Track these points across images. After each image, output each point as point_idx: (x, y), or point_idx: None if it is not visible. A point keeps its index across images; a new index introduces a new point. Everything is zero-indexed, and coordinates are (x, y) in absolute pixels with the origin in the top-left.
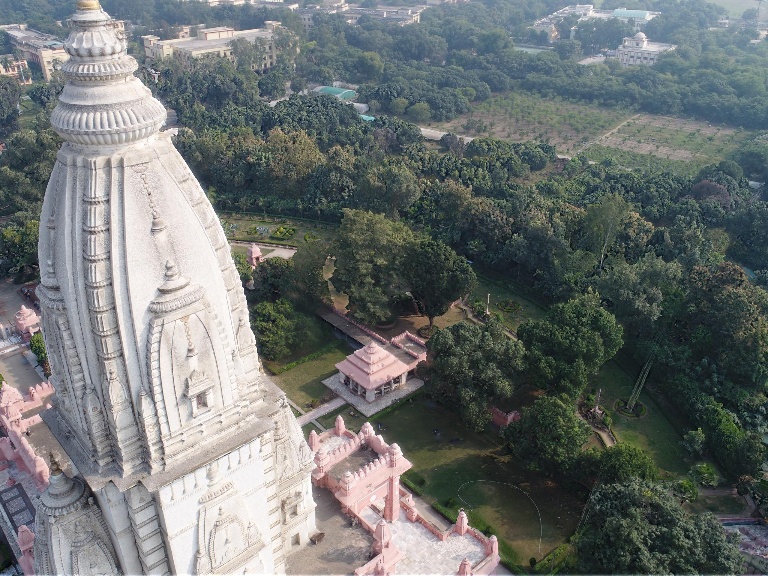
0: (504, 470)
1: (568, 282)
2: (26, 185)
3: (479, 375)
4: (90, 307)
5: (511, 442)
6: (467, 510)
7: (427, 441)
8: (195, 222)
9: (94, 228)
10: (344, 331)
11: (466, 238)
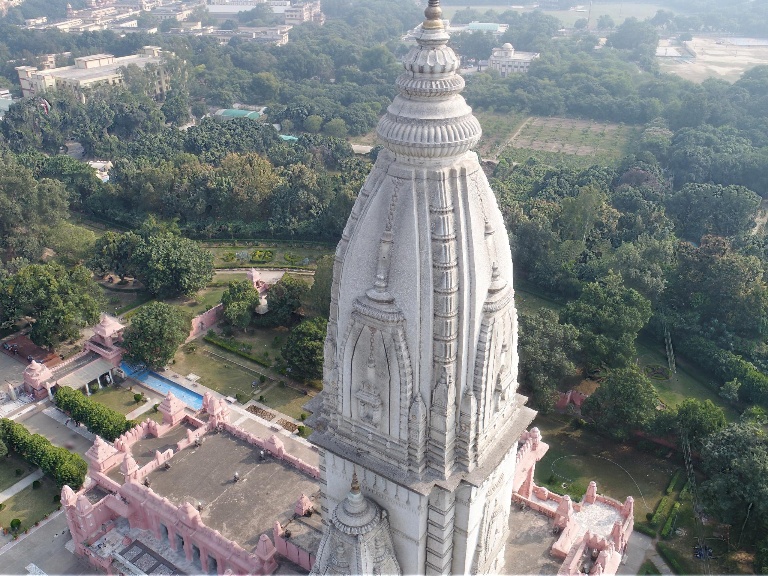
0: (581, 444)
1: (566, 270)
2: None
3: (545, 360)
4: (439, 314)
5: None
6: (569, 484)
7: None
8: None
9: (448, 236)
10: None
11: None
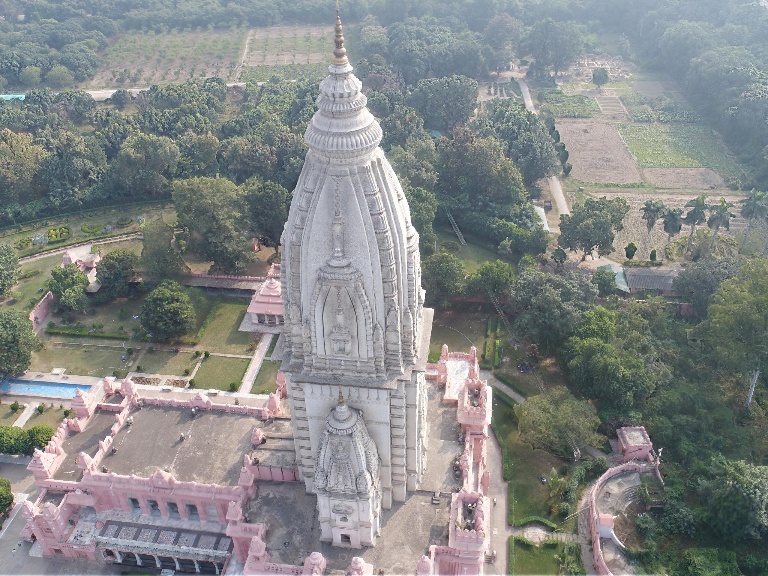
0: None
1: None
2: None
3: None
4: (385, 264)
5: None
6: None
7: None
8: None
9: (382, 210)
10: (219, 287)
11: (240, 177)
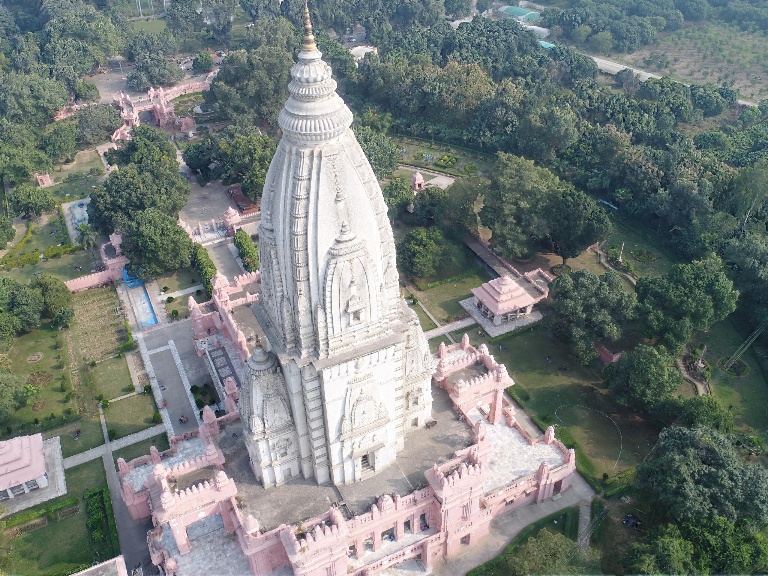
0: (600, 400)
1: (703, 241)
2: (237, 99)
3: (592, 318)
4: (292, 247)
5: (610, 378)
6: (560, 427)
7: (539, 365)
8: (364, 195)
9: (299, 196)
10: (485, 260)
11: (615, 185)
